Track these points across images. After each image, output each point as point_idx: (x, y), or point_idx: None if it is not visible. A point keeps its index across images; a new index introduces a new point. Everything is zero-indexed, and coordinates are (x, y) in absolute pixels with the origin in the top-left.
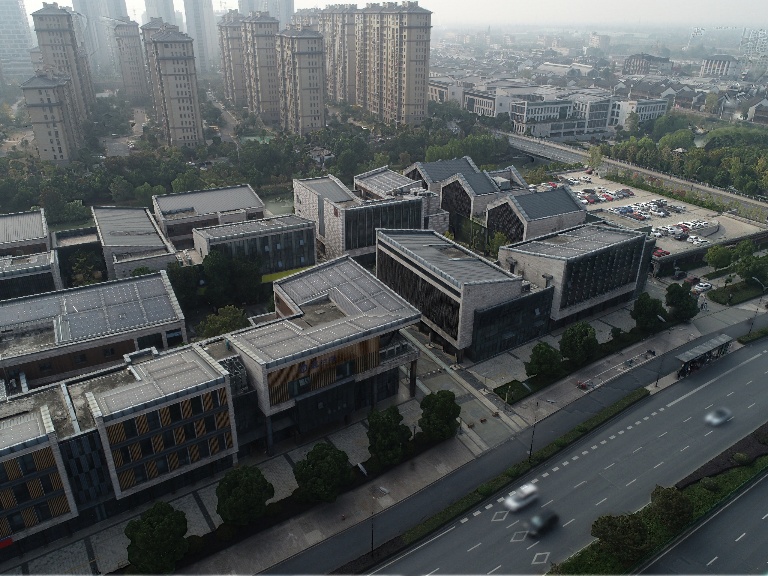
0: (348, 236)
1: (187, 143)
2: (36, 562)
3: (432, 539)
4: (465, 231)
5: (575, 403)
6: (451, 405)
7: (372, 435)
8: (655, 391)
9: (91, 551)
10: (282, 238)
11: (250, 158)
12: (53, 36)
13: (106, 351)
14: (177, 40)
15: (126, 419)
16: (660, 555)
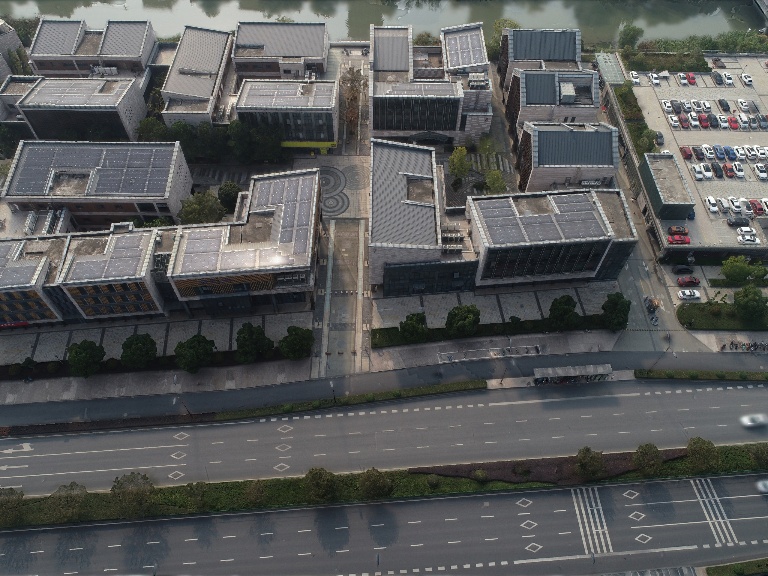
0: (376, 118)
1: None
2: (44, 335)
3: (235, 423)
4: (514, 132)
5: (422, 368)
6: (300, 342)
7: (237, 341)
8: (495, 387)
9: (70, 341)
10: (302, 116)
11: None
12: None
13: (117, 206)
14: None
15: (78, 286)
16: (350, 504)
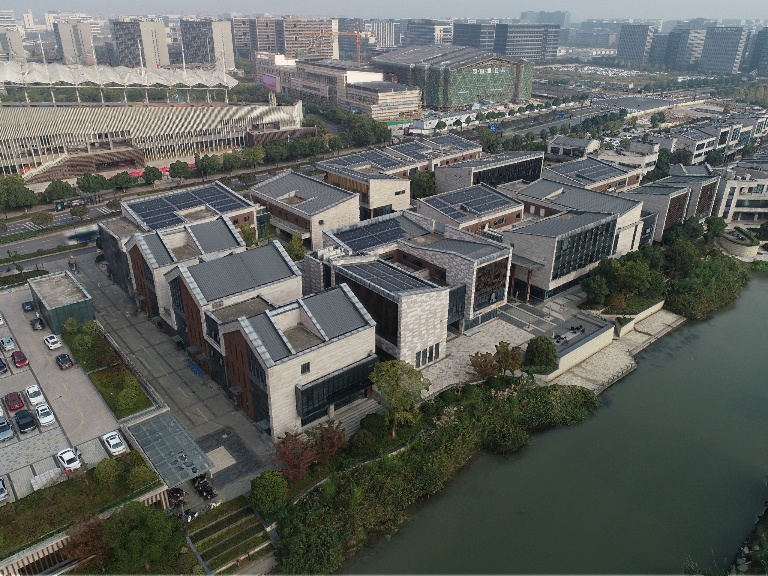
0: None
1: None
2: None
3: None
4: None
5: None
6: None
7: None
8: None
9: None
10: None
11: None
12: None
13: None
14: None
15: None
16: None
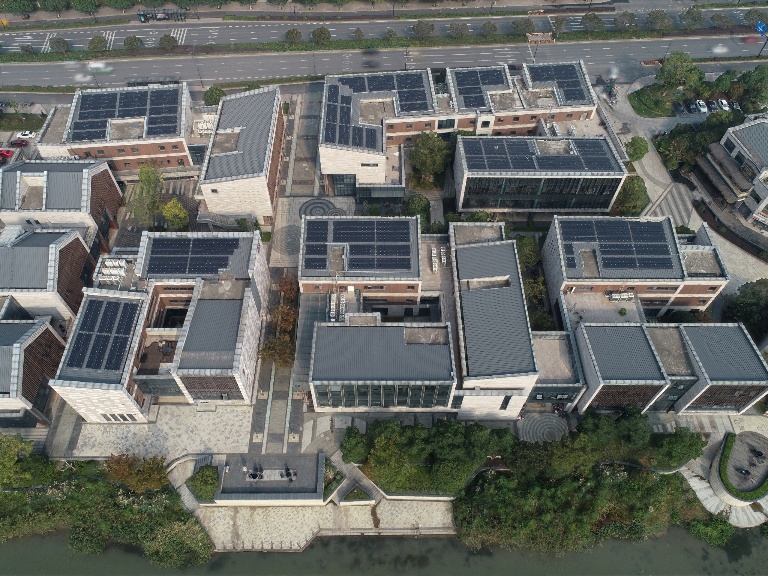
0: None
1: None
2: None
3: None
4: None
5: None
6: None
7: None
8: (208, 86)
9: None
10: None
11: None
12: None
13: None
14: None
15: None
16: None
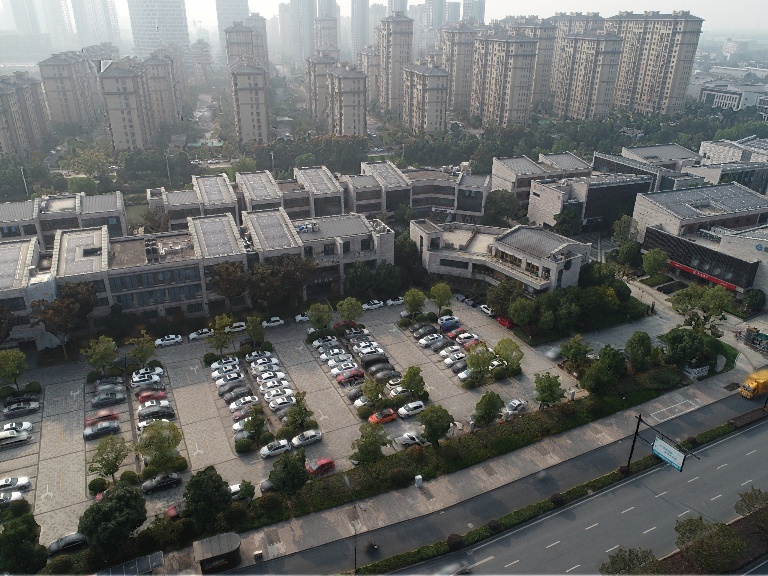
0: None
1: (518, 122)
2: None
3: None
4: None
5: None
6: None
7: None
8: None
9: None
10: (755, 173)
11: (590, 133)
12: (403, 37)
13: (746, 219)
14: (530, 41)
15: None
16: None
